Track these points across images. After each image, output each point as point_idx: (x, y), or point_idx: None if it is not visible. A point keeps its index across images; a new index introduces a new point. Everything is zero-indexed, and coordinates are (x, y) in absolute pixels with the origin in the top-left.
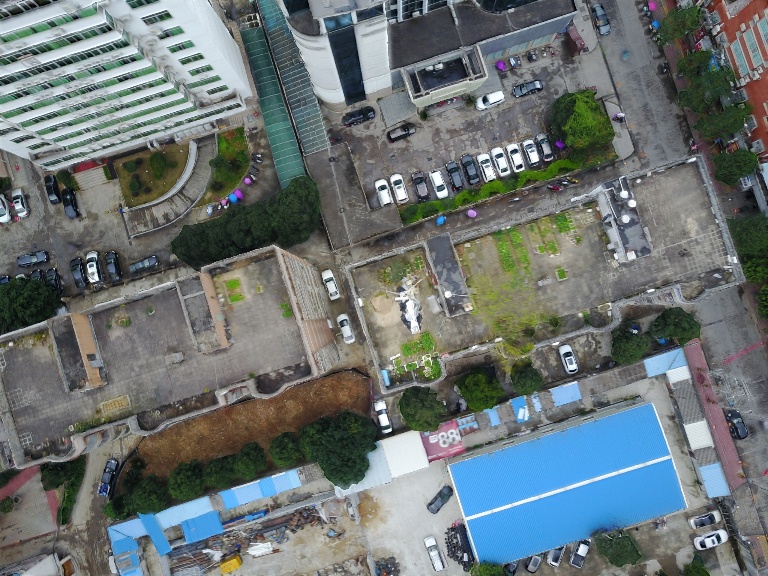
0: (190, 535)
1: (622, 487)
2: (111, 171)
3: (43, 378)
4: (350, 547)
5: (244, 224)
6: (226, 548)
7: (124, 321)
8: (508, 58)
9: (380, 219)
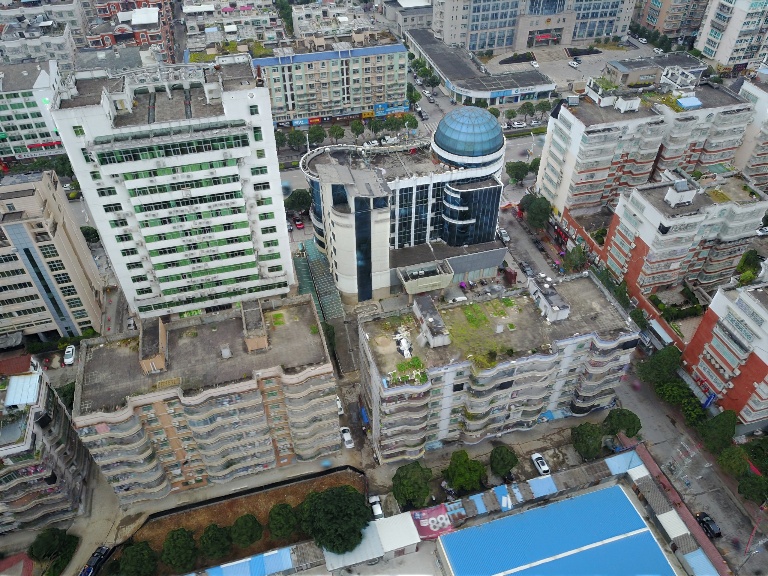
0: None
1: (610, 558)
2: None
3: (118, 366)
4: None
5: None
6: None
7: (193, 333)
8: (468, 281)
9: None
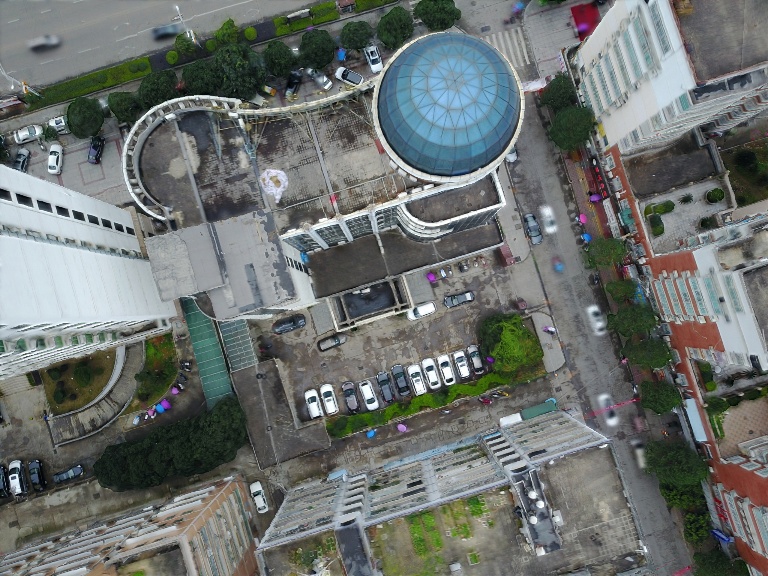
0: None
1: None
2: (35, 377)
3: None
4: None
5: (166, 455)
6: None
7: None
8: (439, 269)
9: (308, 438)
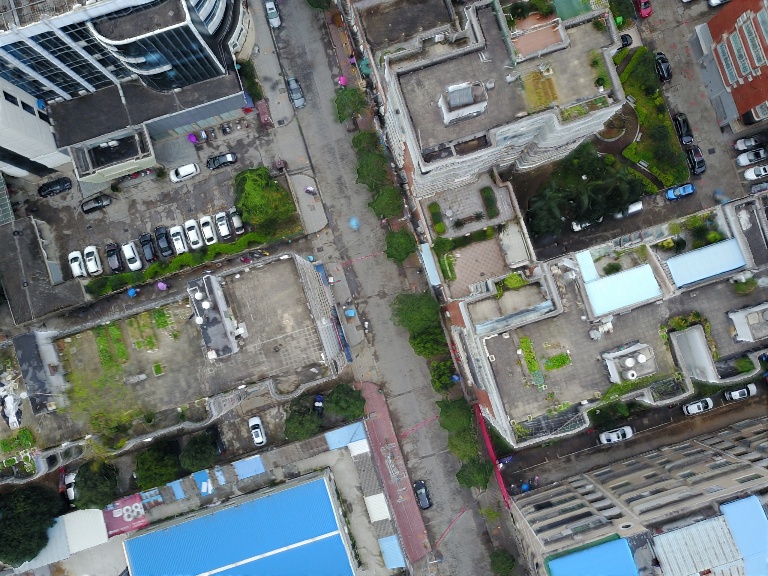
0: None
1: (292, 562)
2: None
3: None
4: None
5: None
6: None
7: None
8: (201, 131)
9: (63, 293)
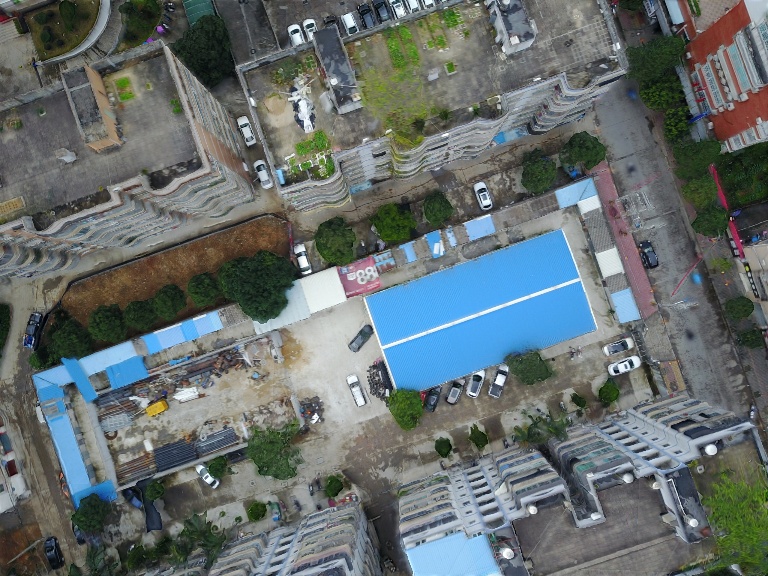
0: (115, 380)
1: (534, 311)
2: (22, 25)
3: None
4: (275, 389)
5: None
6: (153, 395)
7: (15, 123)
8: None
9: None
